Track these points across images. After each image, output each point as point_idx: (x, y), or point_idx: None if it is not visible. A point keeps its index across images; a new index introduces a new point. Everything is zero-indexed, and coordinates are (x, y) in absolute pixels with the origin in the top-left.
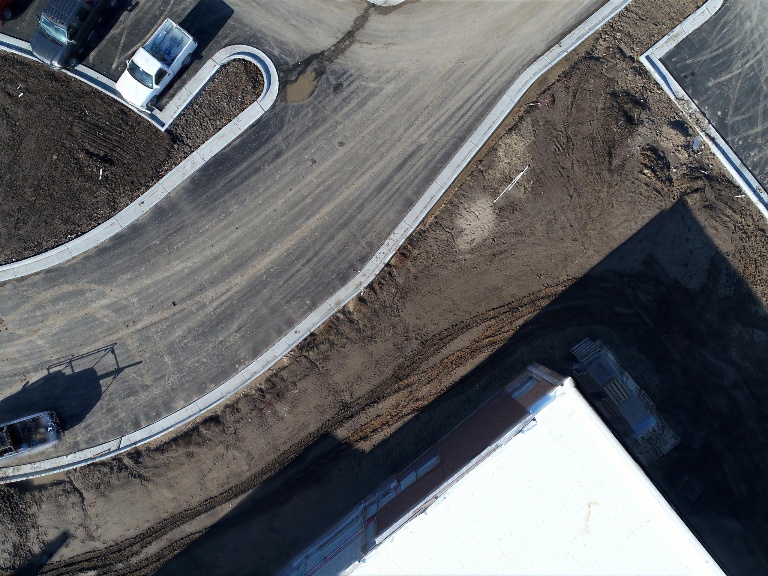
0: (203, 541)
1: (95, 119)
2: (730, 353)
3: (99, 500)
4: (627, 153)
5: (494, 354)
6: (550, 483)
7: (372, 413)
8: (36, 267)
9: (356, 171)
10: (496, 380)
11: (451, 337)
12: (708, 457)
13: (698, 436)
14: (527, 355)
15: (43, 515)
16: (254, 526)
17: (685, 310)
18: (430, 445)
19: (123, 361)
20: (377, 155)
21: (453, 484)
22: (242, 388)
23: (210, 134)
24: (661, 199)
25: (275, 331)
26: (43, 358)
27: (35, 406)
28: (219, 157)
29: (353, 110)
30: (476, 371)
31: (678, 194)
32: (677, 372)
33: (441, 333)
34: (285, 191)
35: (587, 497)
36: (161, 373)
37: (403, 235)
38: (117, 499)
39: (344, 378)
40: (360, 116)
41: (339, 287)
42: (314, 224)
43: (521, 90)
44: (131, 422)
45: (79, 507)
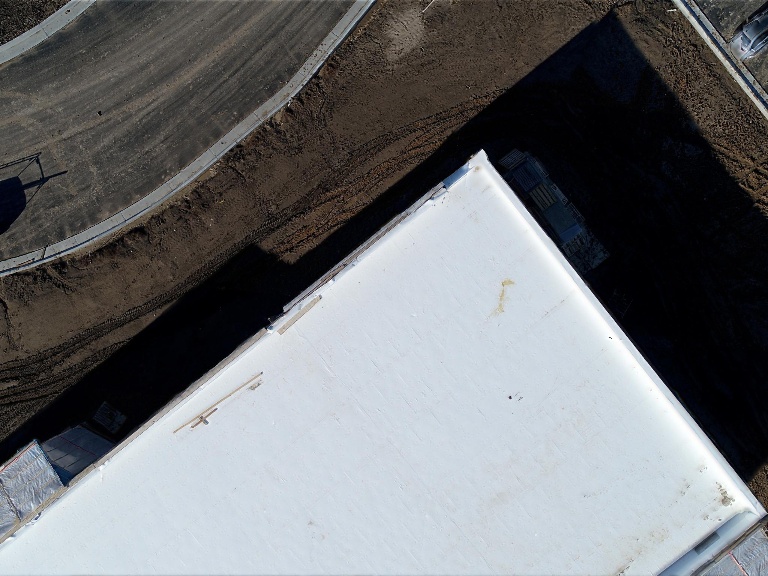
0: (126, 351)
1: None
2: (660, 166)
3: (22, 309)
4: None
5: (421, 165)
6: (463, 260)
7: (298, 224)
8: None
9: None
10: (423, 191)
11: (378, 148)
12: (637, 272)
13: (627, 250)
14: (455, 166)
15: None
16: (178, 336)
17: (615, 123)
18: None
19: (48, 171)
20: None
21: (362, 252)
22: (168, 200)
23: None
24: (591, 11)
25: (201, 142)
26: None
27: None
28: None
29: None
30: (403, 182)
31: (609, 6)
32: (606, 185)
33: (368, 143)
34: (213, 1)
35: (501, 275)
36: (86, 183)
37: (331, 46)
38: (40, 308)
39: (270, 188)
40: None
41: (266, 98)
42: (241, 34)
43: None
44: (55, 232)
45: (2, 316)
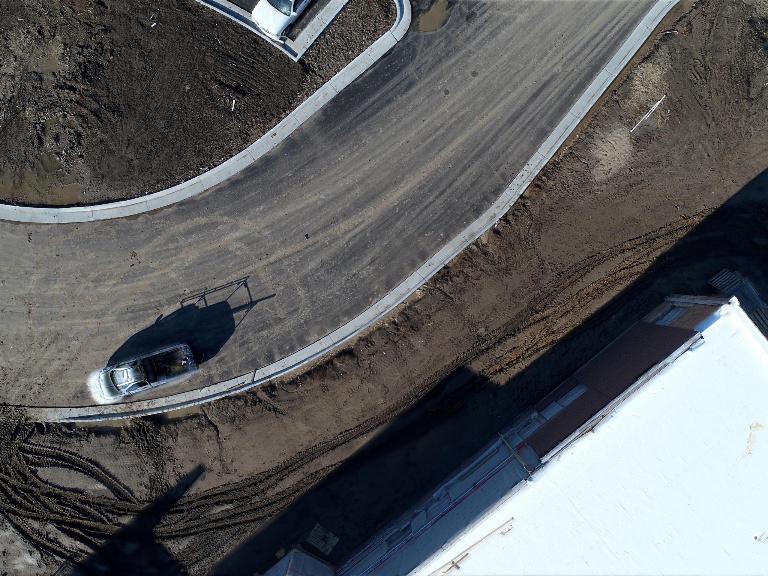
0: (338, 474)
1: (228, 49)
2: None
3: (234, 433)
4: (766, 81)
5: (631, 285)
6: (711, 404)
7: (507, 345)
8: (169, 200)
9: (490, 101)
10: (632, 312)
11: (587, 269)
12: None
13: None
14: (664, 286)
15: (179, 448)
16: (389, 459)
17: None
18: (566, 377)
19: (256, 294)
20: (511, 85)
21: (619, 403)
22: (375, 321)
23: (342, 65)
24: None
25: (408, 264)
26: (176, 292)
27: (169, 340)
28: (351, 88)
29: (487, 39)
30: (612, 303)
31: None
32: None
33: (577, 265)
34: (418, 122)
35: (748, 418)
36: (294, 306)
37: (537, 166)
38: (252, 432)
39: (479, 310)
40: (494, 45)
41: (473, 219)
42: (447, 155)
43: (658, 18)
44: (265, 355)
45: (214, 440)
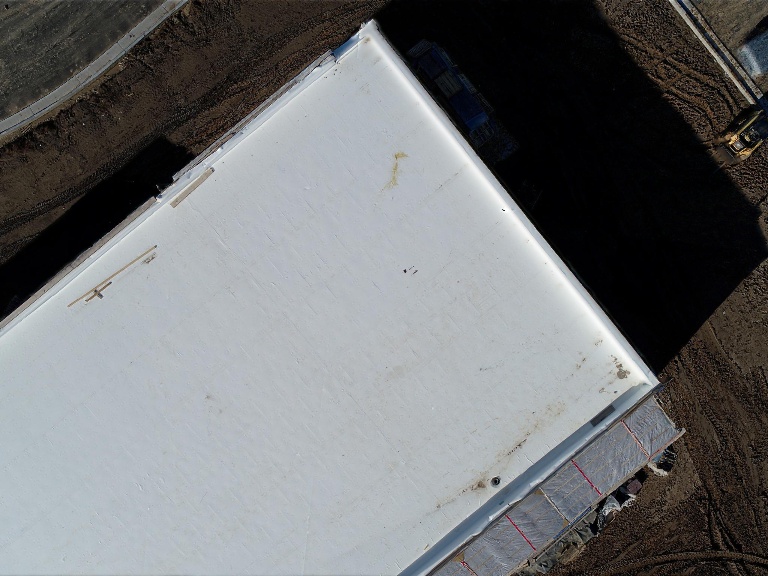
0: (36, 245)
1: None
2: (568, 57)
3: None
4: None
5: None
6: (356, 132)
7: (207, 116)
8: None
9: None
10: None
11: (286, 39)
12: (546, 162)
13: (536, 141)
14: None
15: None
16: (88, 230)
17: (524, 14)
18: None
19: None
20: None
21: (251, 120)
22: (77, 94)
23: None
24: None
25: (110, 35)
26: None
27: None
28: None
29: None
30: None
31: None
32: (515, 76)
33: (276, 35)
34: None
35: (394, 148)
36: None
37: None
38: None
39: (178, 81)
40: None
41: None
42: None
43: None
44: None
45: None
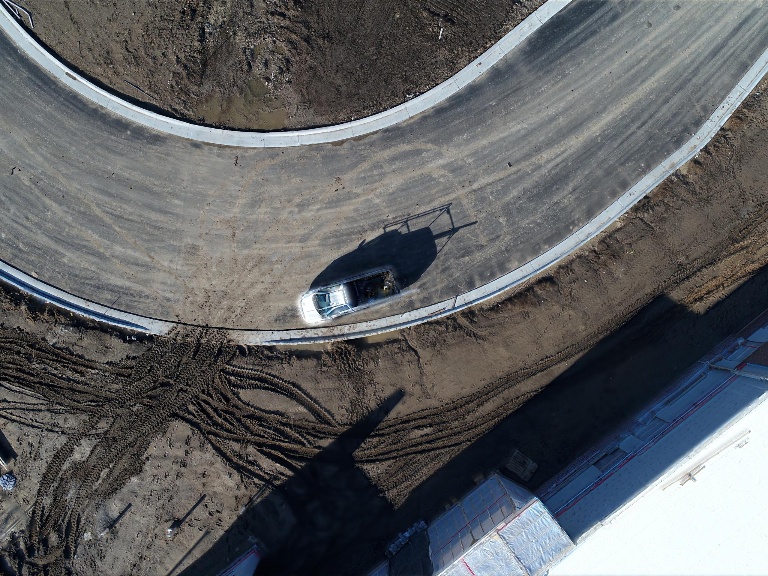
0: (539, 400)
1: None
2: None
3: (435, 358)
4: None
5: None
6: None
7: (708, 275)
8: (374, 126)
9: (691, 35)
10: None
11: None
12: None
13: None
14: None
15: (380, 372)
16: (589, 386)
17: None
18: (765, 307)
19: (458, 221)
20: (713, 19)
21: None
22: (575, 250)
23: None
24: None
25: (609, 193)
26: (379, 217)
27: (371, 265)
28: (555, 19)
29: None
30: None
31: None
32: None
33: None
34: (620, 54)
35: None
36: (496, 233)
37: (738, 99)
38: (453, 357)
39: (680, 240)
40: None
41: (673, 150)
42: (649, 87)
43: None
44: (465, 282)
45: (415, 365)
